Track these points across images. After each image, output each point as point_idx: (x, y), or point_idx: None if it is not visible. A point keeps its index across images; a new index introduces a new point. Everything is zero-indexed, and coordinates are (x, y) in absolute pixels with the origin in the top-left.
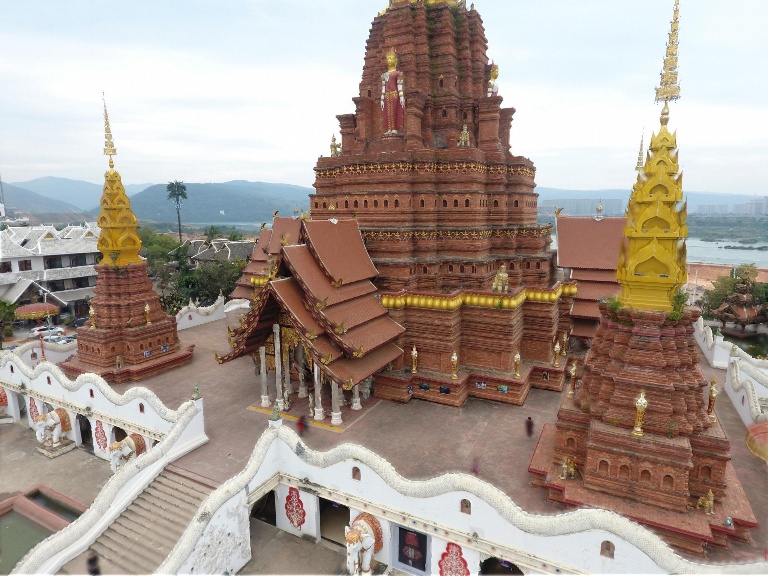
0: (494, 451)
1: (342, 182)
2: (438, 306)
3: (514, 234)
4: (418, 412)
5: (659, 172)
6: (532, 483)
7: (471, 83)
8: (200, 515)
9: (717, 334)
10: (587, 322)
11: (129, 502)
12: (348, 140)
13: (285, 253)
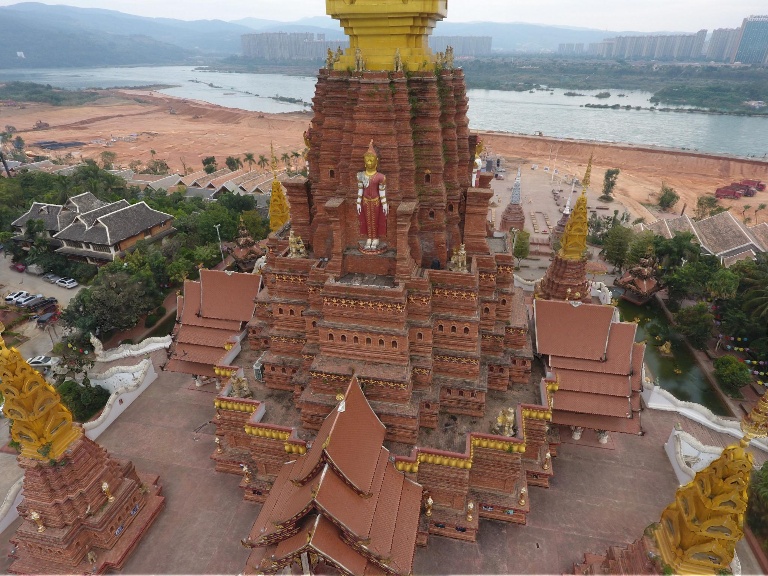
0: None
1: (323, 314)
2: (455, 465)
3: (503, 338)
4: (442, 561)
5: (733, 493)
6: None
7: (457, 167)
8: None
9: (655, 384)
10: (566, 412)
11: None
12: (300, 210)
13: (318, 504)
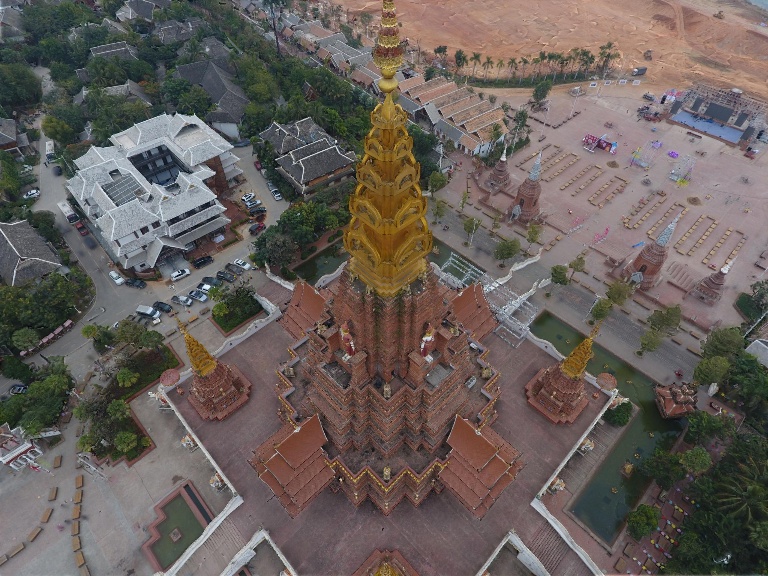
0: (350, 553)
1: None
2: None
3: (417, 428)
4: (337, 504)
5: None
6: None
7: None
8: (232, 563)
9: (537, 497)
10: None
11: (214, 530)
12: None
13: None
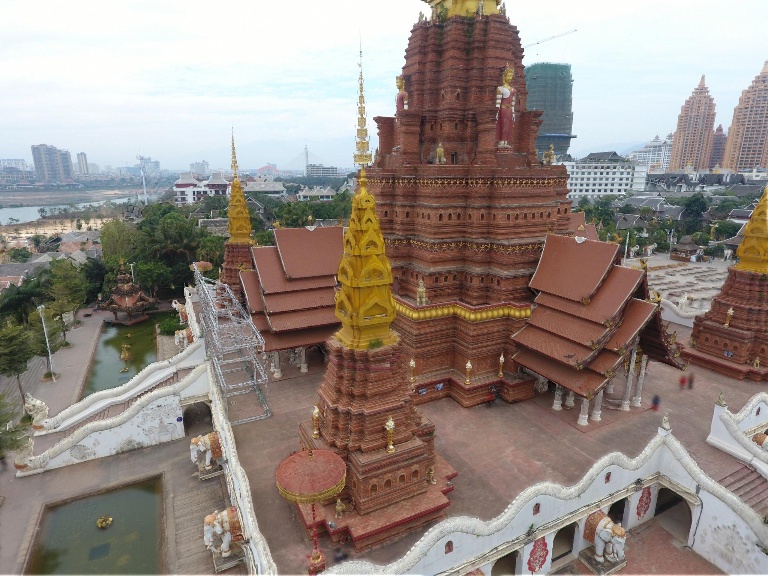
0: None
1: None
2: None
3: None
4: None
5: None
6: None
7: None
8: None
9: None
10: None
11: None
12: None
13: None
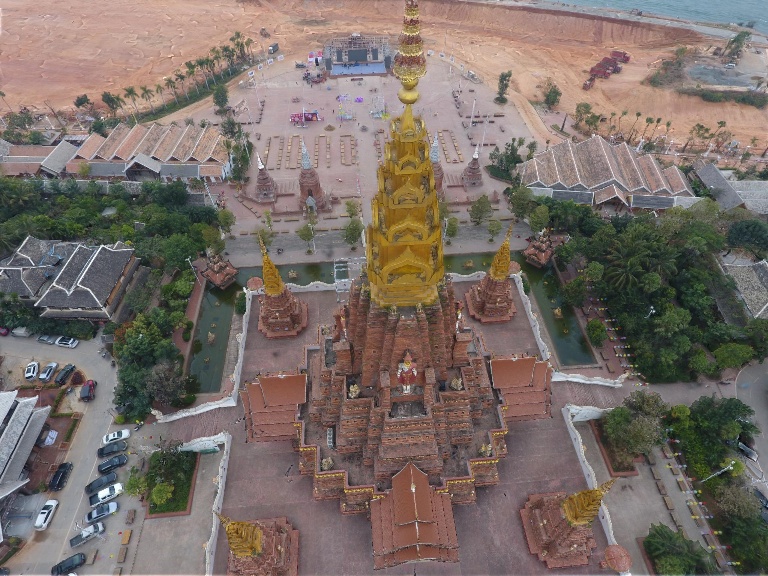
0: (507, 535)
1: None
2: None
3: None
4: (461, 518)
5: None
6: None
7: None
8: None
9: (556, 371)
10: None
11: None
12: (344, 357)
13: None
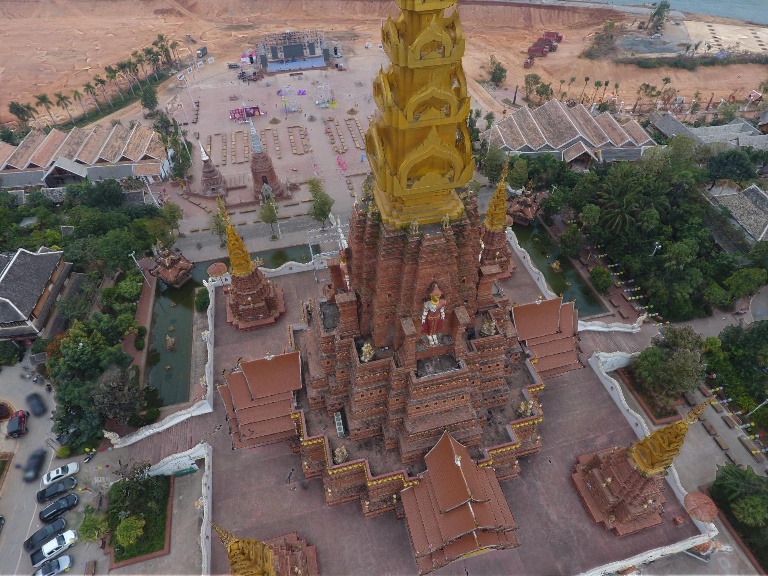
0: (563, 507)
1: None
2: None
3: None
4: (506, 497)
5: None
6: (594, 522)
7: None
8: None
9: None
10: None
11: None
12: (349, 313)
13: None
